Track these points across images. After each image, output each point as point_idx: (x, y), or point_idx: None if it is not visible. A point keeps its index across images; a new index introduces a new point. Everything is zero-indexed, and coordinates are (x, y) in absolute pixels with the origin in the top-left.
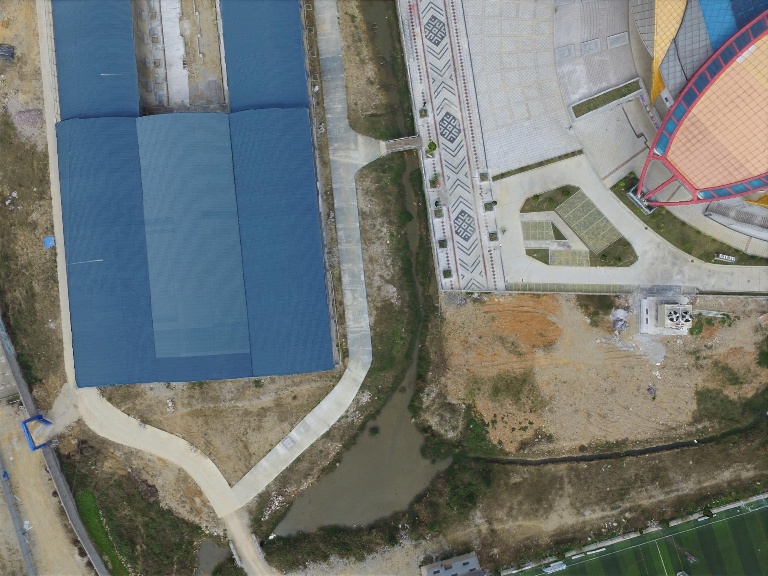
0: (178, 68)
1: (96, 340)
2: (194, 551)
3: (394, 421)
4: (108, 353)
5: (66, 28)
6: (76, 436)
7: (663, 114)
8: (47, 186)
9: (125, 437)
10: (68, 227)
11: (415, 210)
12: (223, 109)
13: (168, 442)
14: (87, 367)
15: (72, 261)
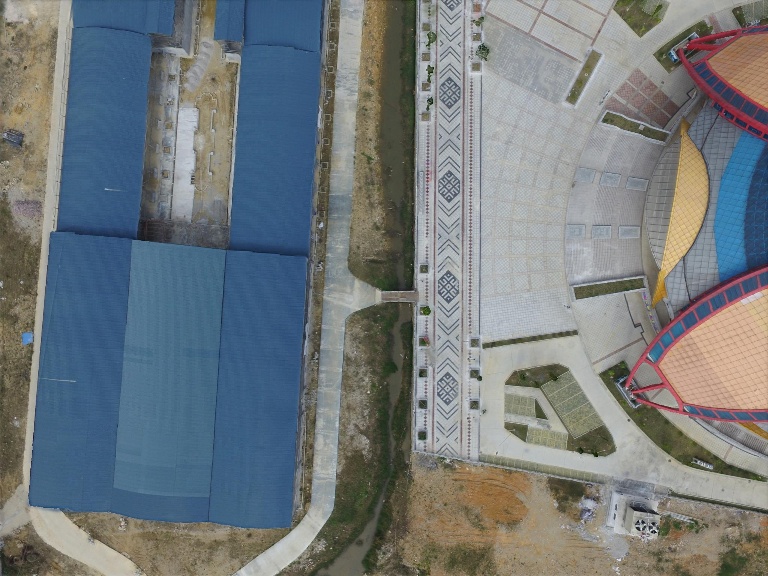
0: (186, 182)
1: (55, 462)
2: None
3: (346, 573)
4: (65, 477)
5: (77, 135)
6: (23, 540)
7: (663, 316)
8: (34, 281)
9: (72, 549)
10: (46, 340)
11: (401, 362)
12: (224, 231)
13: (115, 561)
14: (42, 487)
15: (44, 376)
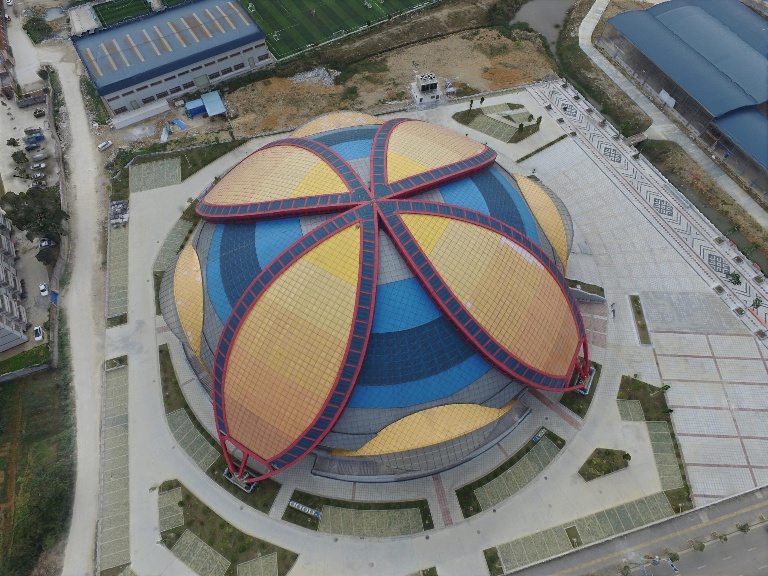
0: None
1: (734, 4)
2: None
3: (550, 32)
4: (724, 1)
5: None
6: None
7: None
8: None
9: None
10: None
11: None
12: None
13: (659, 1)
14: None
15: None
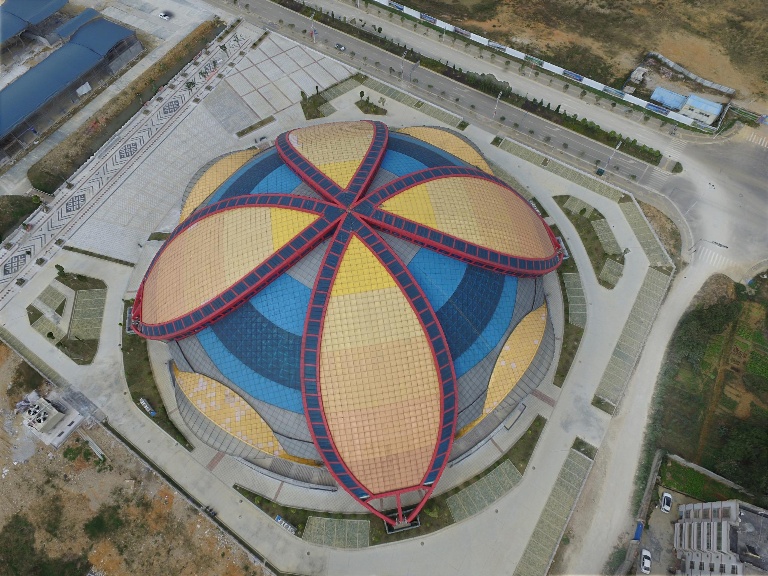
0: None
1: None
2: None
3: None
4: None
5: None
6: None
7: None
8: None
9: None
10: None
11: None
12: None
13: None
14: None
15: None
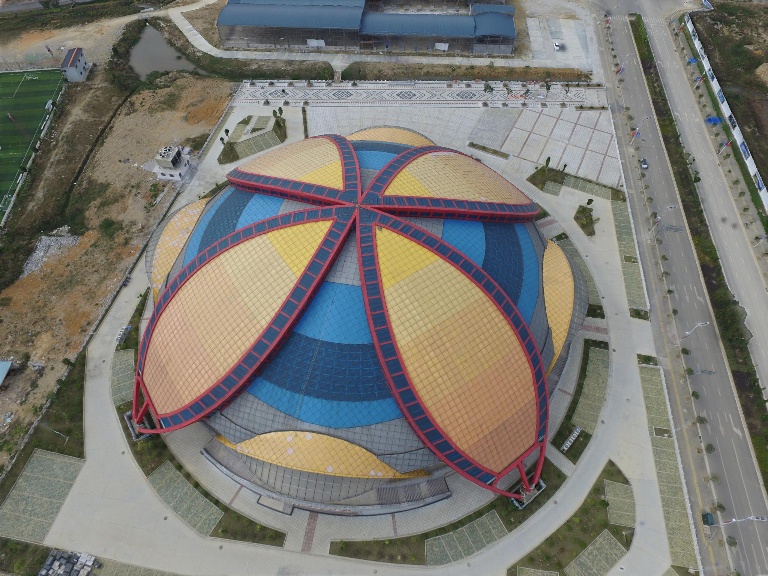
0: None
1: None
2: (158, 4)
3: (180, 64)
4: None
5: None
6: None
7: None
8: None
9: None
10: None
11: None
12: None
13: None
14: None
15: None
